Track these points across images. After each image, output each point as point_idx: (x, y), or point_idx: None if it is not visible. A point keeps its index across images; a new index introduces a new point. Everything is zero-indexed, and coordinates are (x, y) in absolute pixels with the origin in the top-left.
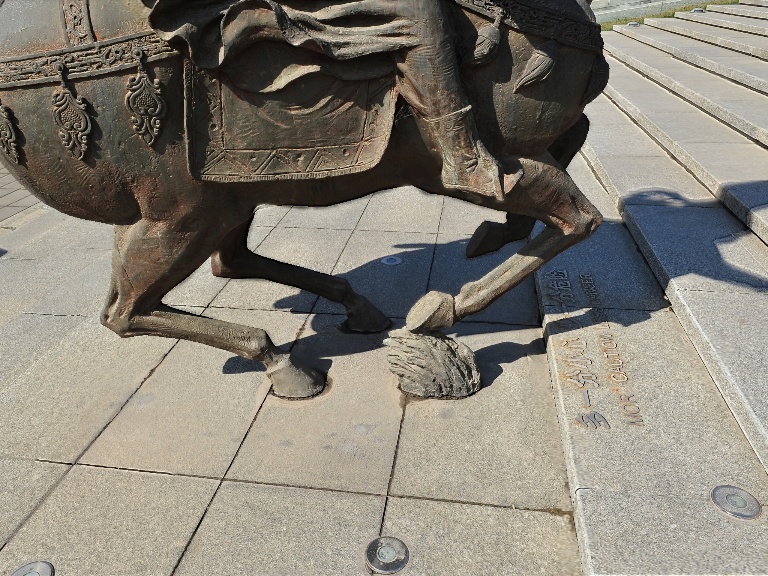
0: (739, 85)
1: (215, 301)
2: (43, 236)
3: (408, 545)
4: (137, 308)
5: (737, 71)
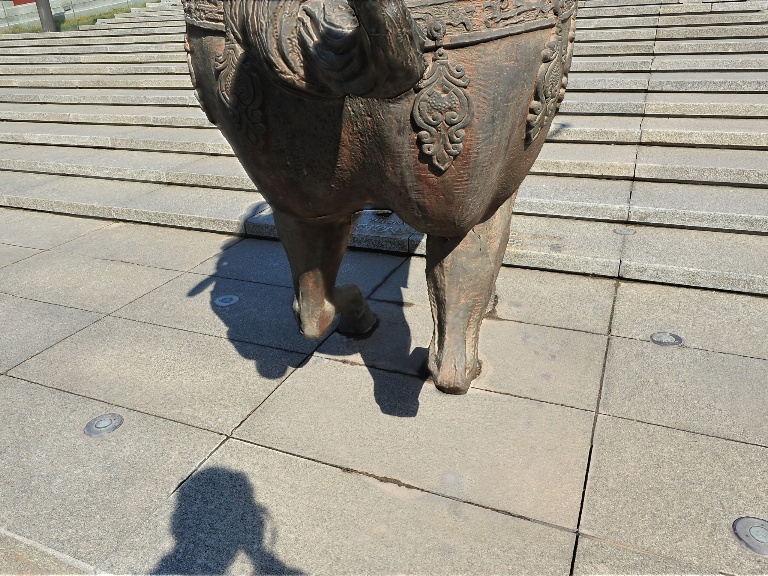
0: (130, 106)
1: (218, 428)
2: None
3: (656, 332)
4: None
5: (115, 96)
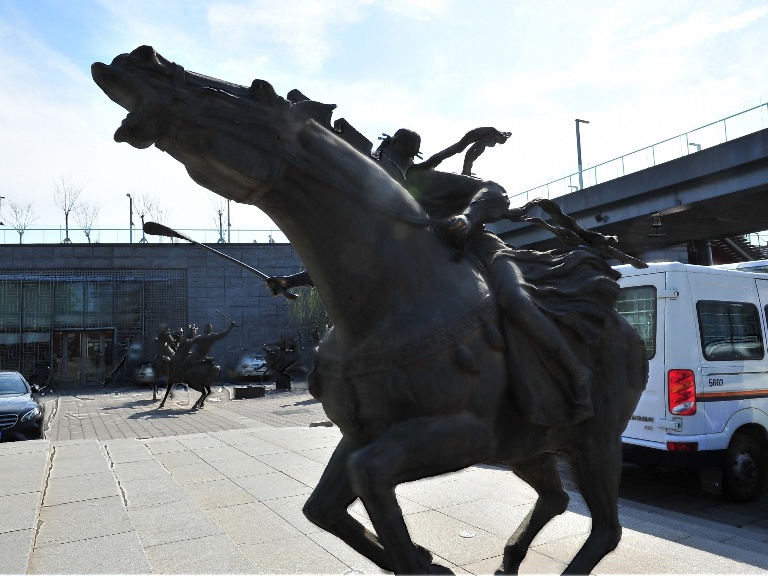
0: None
1: None
2: None
3: None
4: None
5: None
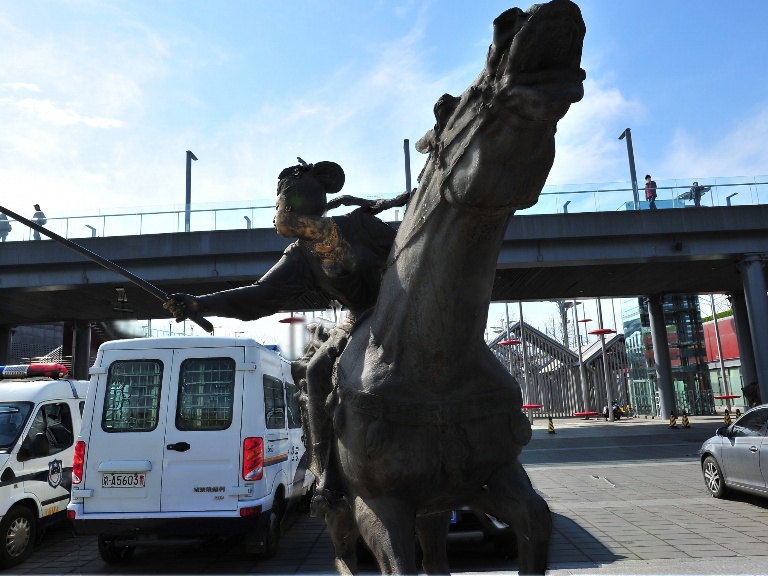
0: None
1: None
2: (615, 568)
3: None
4: (338, 552)
5: None
